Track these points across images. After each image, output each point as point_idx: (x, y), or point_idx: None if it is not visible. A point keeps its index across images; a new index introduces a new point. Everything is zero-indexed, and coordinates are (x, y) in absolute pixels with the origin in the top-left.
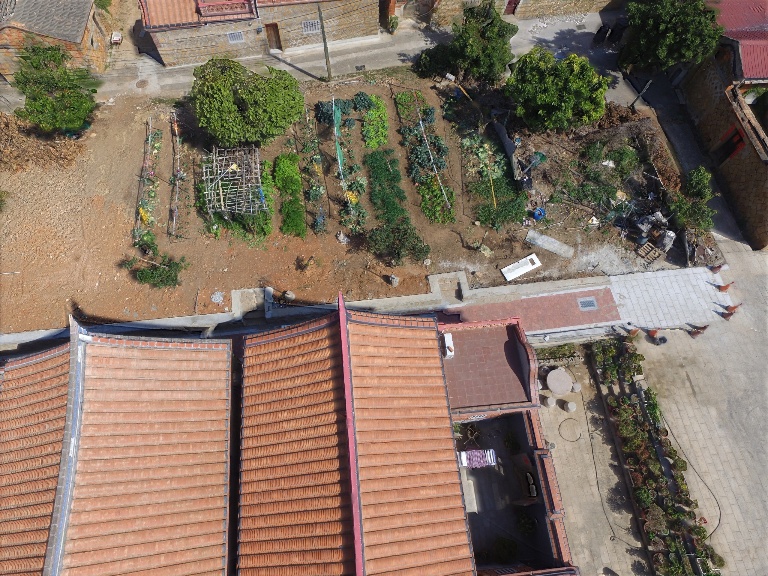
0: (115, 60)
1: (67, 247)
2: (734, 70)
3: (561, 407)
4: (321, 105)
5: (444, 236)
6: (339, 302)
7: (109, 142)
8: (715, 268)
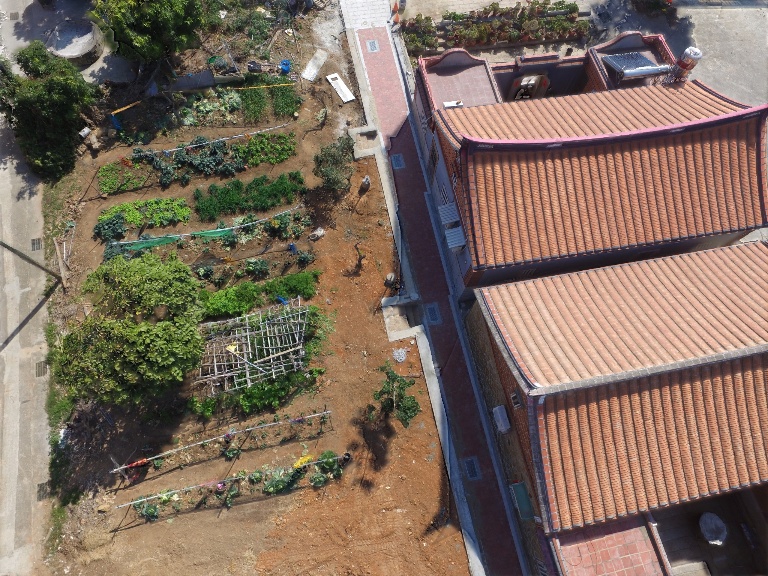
0: None
1: None
2: None
3: None
4: None
5: (310, 145)
6: (466, 138)
7: None
8: None
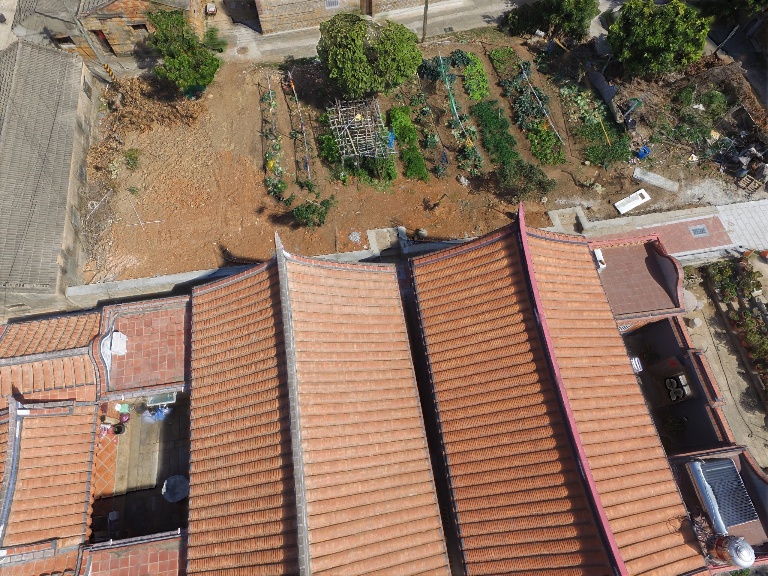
0: (212, 30)
1: (205, 197)
2: None
3: (686, 324)
4: (423, 62)
5: (556, 176)
6: (519, 212)
7: (226, 102)
8: None
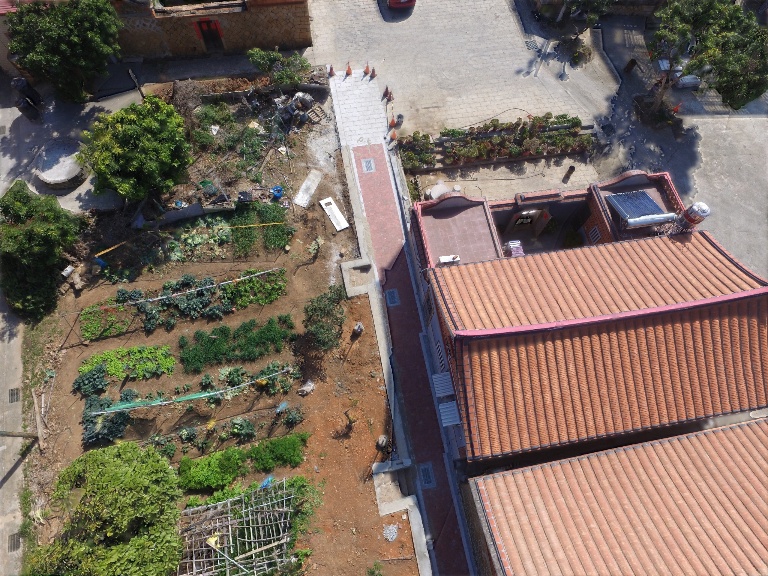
0: None
1: None
2: (137, 2)
3: None
4: (93, 438)
5: (301, 282)
6: (461, 335)
7: None
8: (332, 72)
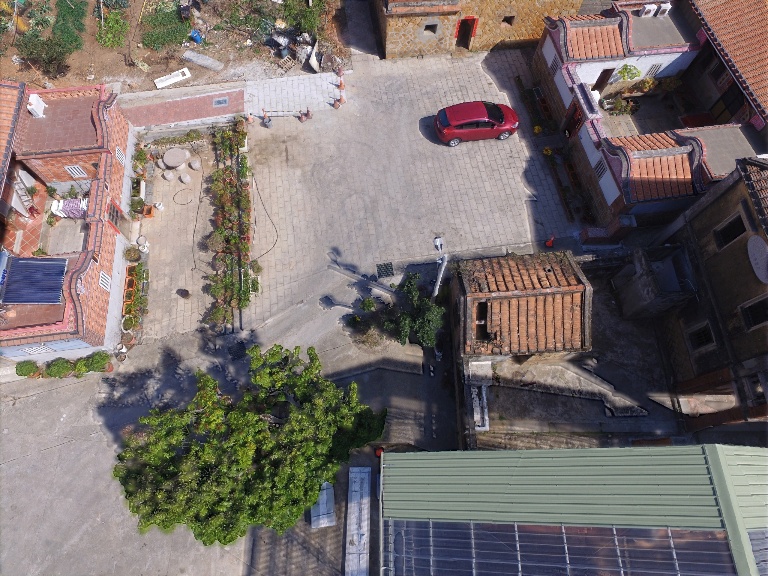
0: None
1: None
2: None
3: (181, 181)
4: None
5: (111, 57)
6: None
7: None
8: (338, 71)
